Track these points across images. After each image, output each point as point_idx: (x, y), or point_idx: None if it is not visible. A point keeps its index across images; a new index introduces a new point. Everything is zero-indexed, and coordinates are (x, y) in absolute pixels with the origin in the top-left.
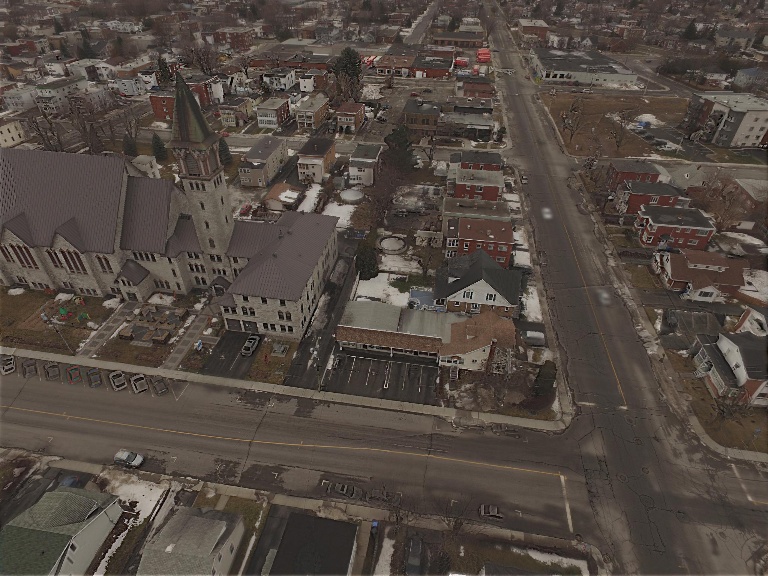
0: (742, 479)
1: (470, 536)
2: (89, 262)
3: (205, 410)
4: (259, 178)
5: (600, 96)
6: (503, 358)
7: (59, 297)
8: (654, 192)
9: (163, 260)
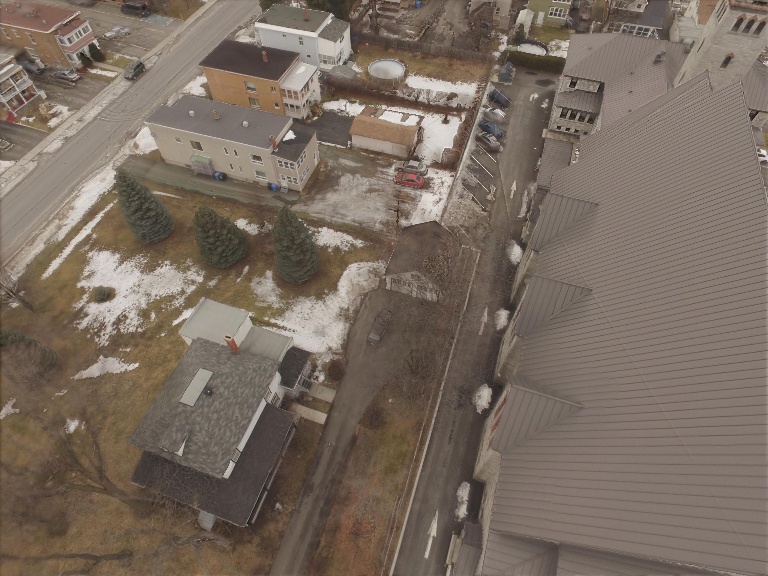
0: None
1: None
2: None
3: None
4: (314, 152)
5: None
6: None
7: None
8: None
9: None
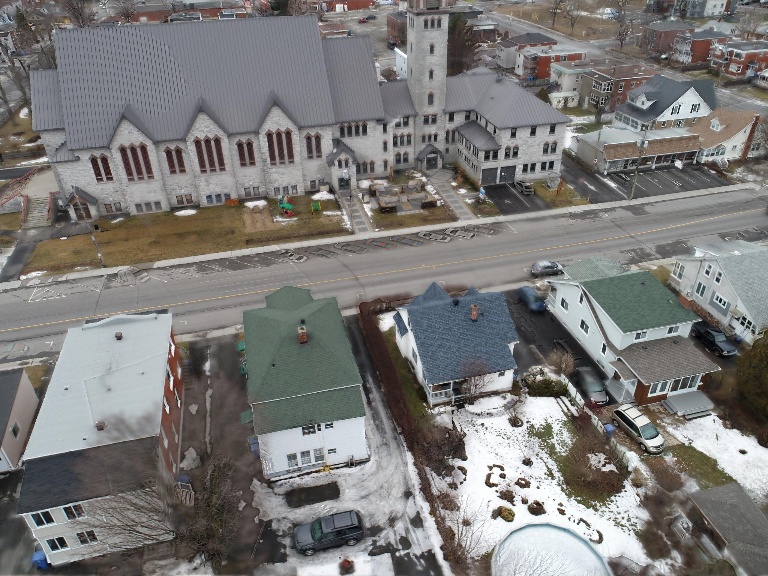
0: None
1: None
2: (299, 144)
3: (555, 231)
4: None
5: (545, 3)
6: (760, 135)
7: (251, 204)
8: (713, 36)
9: (376, 130)
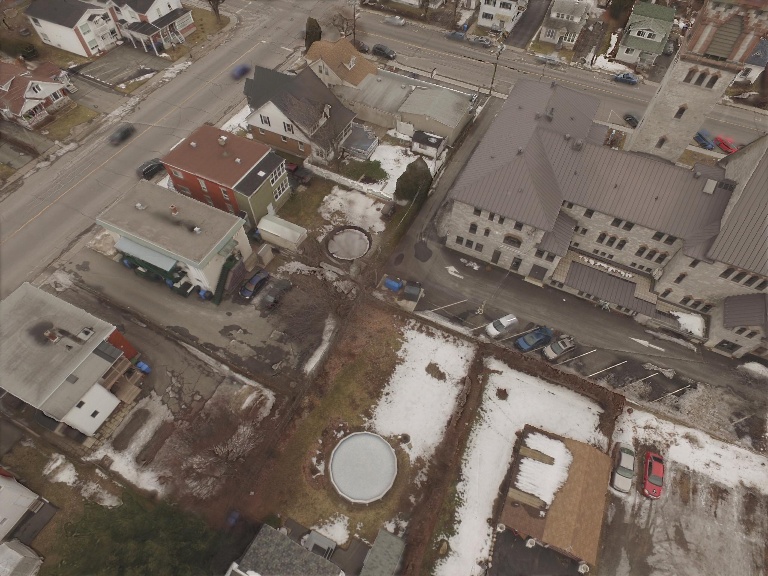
0: (242, 8)
1: (416, 14)
2: None
3: None
4: None
5: None
6: None
7: None
8: None
9: None
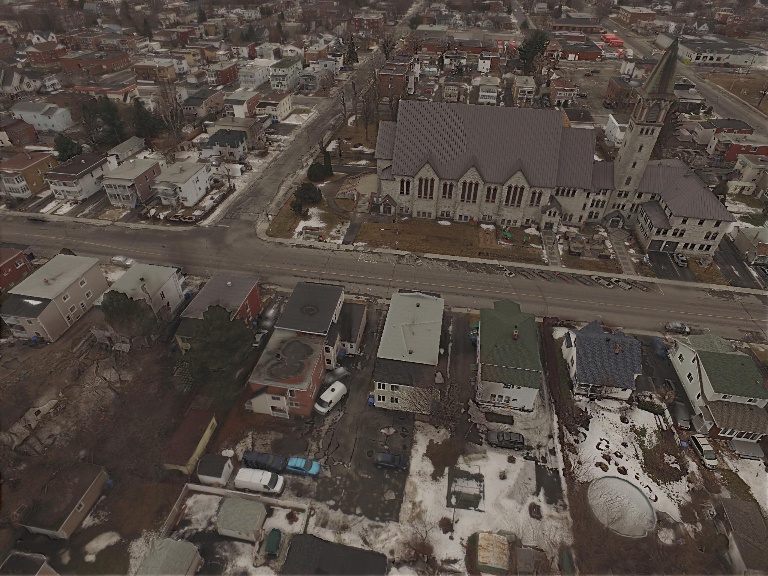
0: None
1: None
2: None
3: (693, 301)
4: None
5: (760, 76)
6: None
7: (485, 227)
8: None
9: (581, 195)
